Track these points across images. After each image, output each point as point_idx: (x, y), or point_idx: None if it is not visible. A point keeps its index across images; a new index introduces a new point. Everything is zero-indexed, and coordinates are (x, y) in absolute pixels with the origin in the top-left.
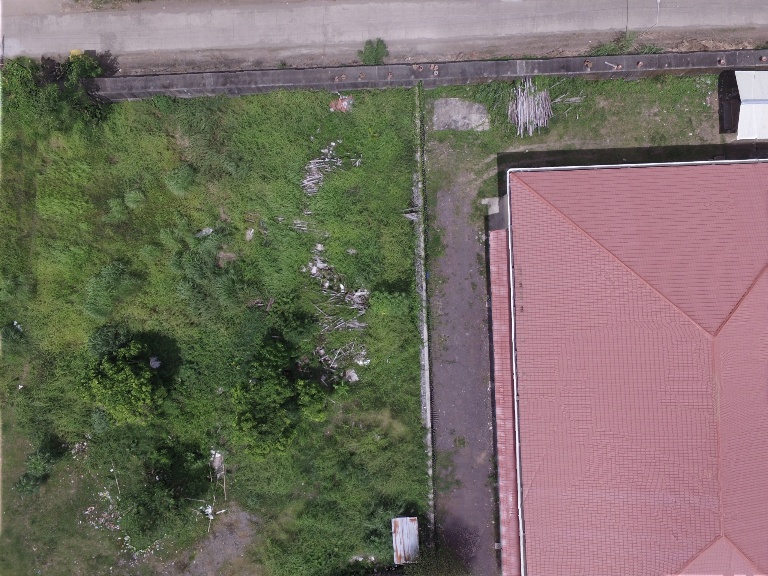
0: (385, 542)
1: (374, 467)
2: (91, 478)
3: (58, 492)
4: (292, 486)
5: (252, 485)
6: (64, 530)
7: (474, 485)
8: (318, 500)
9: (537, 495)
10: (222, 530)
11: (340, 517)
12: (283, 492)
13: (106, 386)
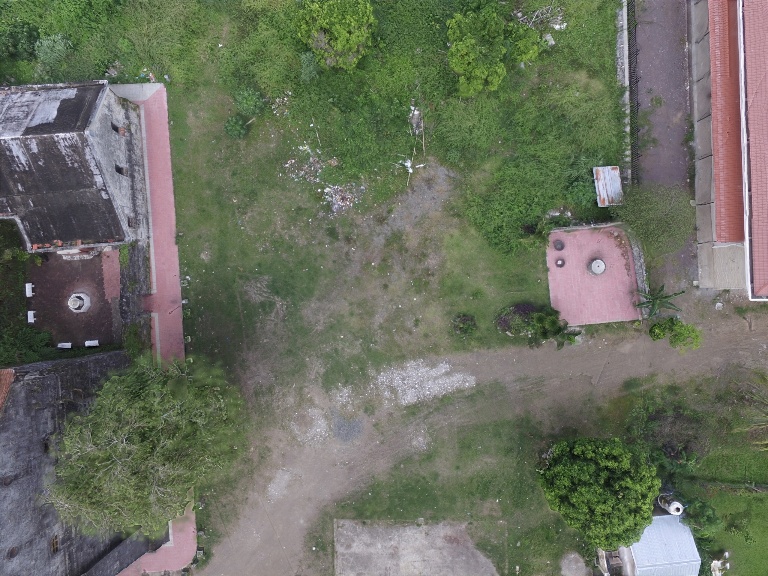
0: (588, 186)
1: (576, 116)
2: (291, 133)
3: (258, 146)
4: (491, 141)
5: (454, 135)
6: (264, 182)
7: (670, 144)
8: (517, 155)
9: (761, 104)
10: (420, 185)
11: (540, 168)
12: (483, 145)
13: (332, 0)
